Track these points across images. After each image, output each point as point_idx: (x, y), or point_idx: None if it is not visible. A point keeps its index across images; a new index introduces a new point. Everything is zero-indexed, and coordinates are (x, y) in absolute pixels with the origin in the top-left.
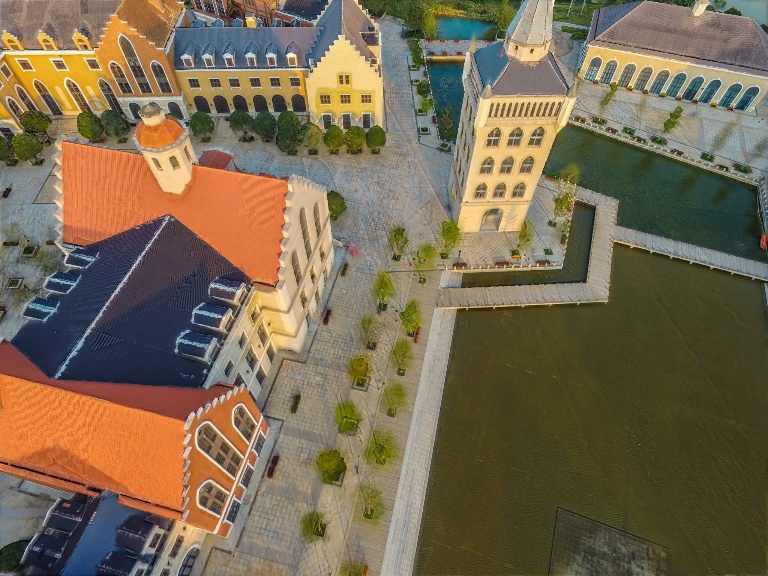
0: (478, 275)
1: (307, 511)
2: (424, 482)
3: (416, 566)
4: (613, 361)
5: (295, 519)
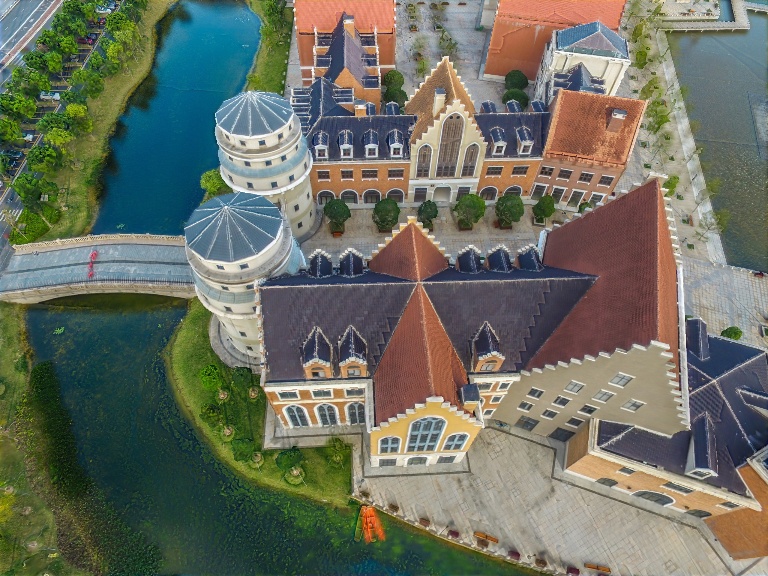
0: (670, 21)
1: (626, 87)
2: (677, 83)
3: (686, 105)
4: (759, 50)
5: (621, 89)
